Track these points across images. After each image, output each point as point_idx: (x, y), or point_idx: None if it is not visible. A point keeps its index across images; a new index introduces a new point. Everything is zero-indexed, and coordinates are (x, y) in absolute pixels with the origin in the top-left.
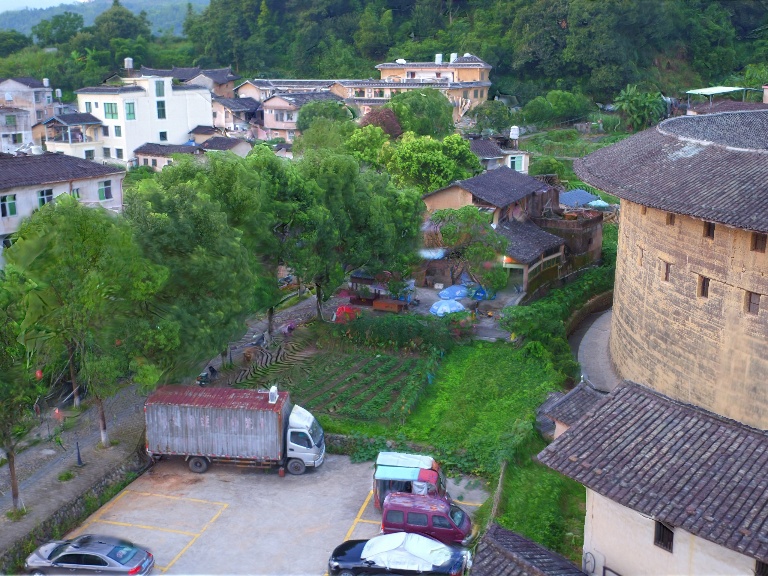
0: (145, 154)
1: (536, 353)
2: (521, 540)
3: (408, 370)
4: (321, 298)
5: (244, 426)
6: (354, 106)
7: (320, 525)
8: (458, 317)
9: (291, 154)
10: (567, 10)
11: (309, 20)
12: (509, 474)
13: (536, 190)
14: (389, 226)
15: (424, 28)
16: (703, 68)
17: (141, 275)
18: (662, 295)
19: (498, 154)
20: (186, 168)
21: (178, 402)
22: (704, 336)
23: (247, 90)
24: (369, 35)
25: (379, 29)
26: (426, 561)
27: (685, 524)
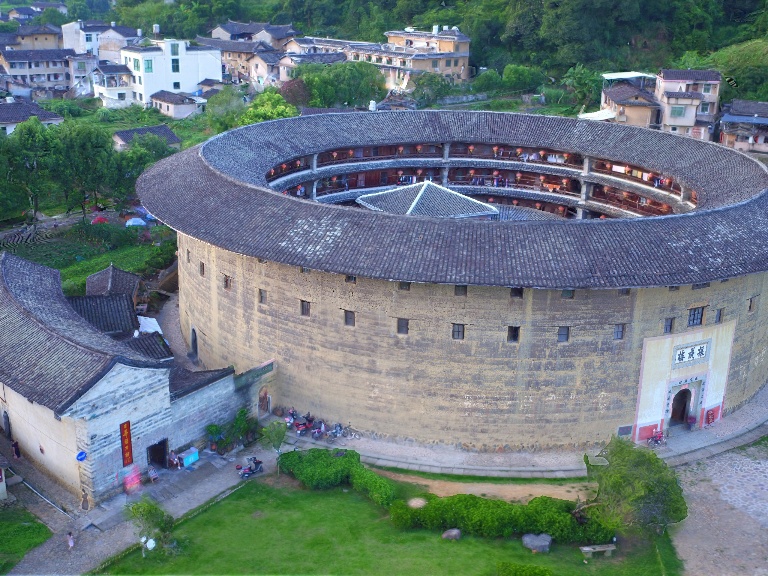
0: (156, 99)
1: None
2: None
3: None
4: (85, 210)
5: None
6: None
7: None
8: (131, 228)
9: None
10: None
11: None
12: None
13: None
14: (108, 170)
15: None
16: (678, 49)
17: None
18: None
19: None
20: None
21: None
22: None
23: (292, 46)
24: (403, 3)
25: None
26: None
27: None
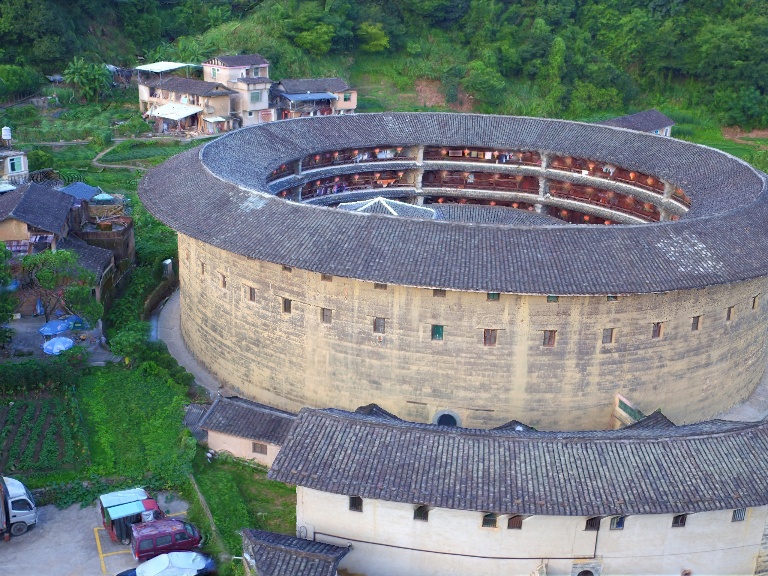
0: None
1: (152, 371)
2: (270, 534)
3: (51, 412)
4: None
5: None
6: None
7: (75, 570)
8: (76, 353)
9: None
10: None
11: None
12: (199, 483)
13: (72, 206)
14: None
15: None
16: (134, 35)
17: None
18: (250, 312)
19: None
20: None
21: None
22: (291, 341)
23: None
24: None
25: None
26: (192, 569)
27: (381, 496)
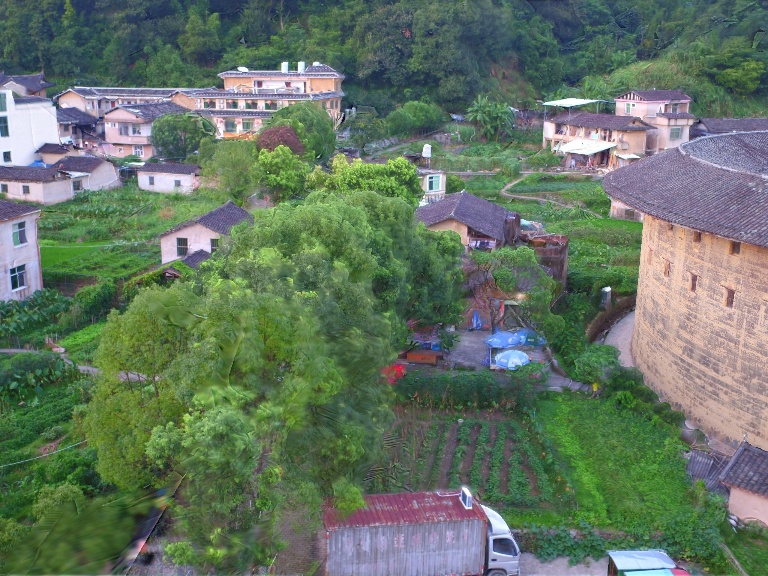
0: None
1: (627, 404)
2: None
3: (510, 436)
4: None
5: (445, 541)
6: (210, 119)
7: None
8: (536, 370)
9: (164, 175)
10: (411, 19)
11: (126, 22)
12: (737, 559)
13: (506, 217)
14: (450, 275)
15: (254, 33)
16: (535, 78)
17: (320, 374)
18: None
19: (417, 174)
20: (283, 228)
21: (365, 522)
22: None
23: (70, 99)
24: (198, 40)
25: (207, 34)
26: None
27: None
